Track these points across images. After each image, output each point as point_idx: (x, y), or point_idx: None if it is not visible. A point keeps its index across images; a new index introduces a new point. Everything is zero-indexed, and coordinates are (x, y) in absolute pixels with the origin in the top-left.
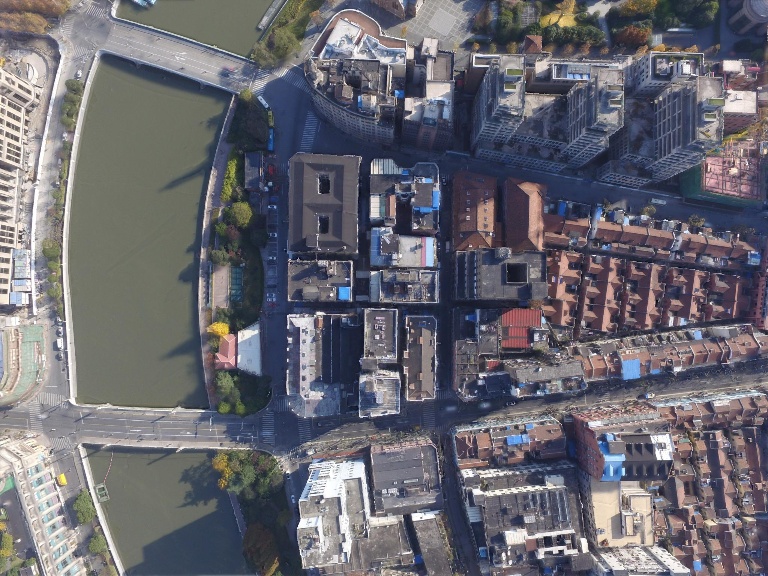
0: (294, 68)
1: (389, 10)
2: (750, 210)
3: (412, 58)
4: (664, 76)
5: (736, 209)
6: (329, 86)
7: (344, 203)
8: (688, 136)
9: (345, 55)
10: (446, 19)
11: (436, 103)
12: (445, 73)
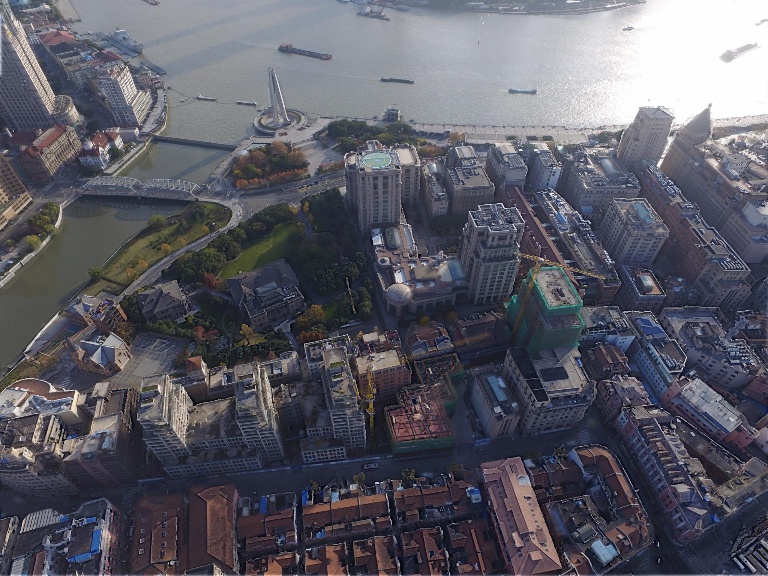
0: None
1: (96, 371)
2: (463, 447)
3: (82, 403)
4: (318, 358)
5: (446, 450)
6: None
7: None
8: (331, 398)
9: (8, 418)
10: (151, 365)
11: (99, 436)
12: (118, 407)
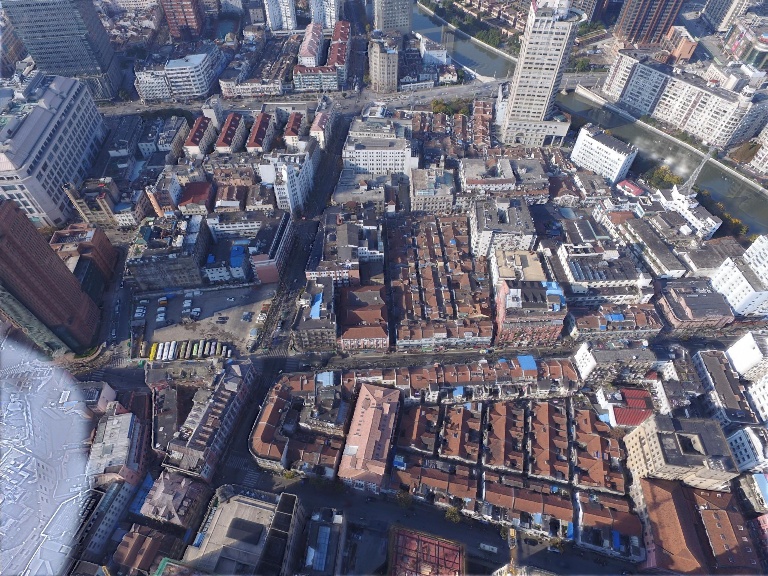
0: None
1: None
2: (378, 530)
3: None
4: None
5: None
6: None
7: None
8: None
9: None
10: None
11: None
12: None
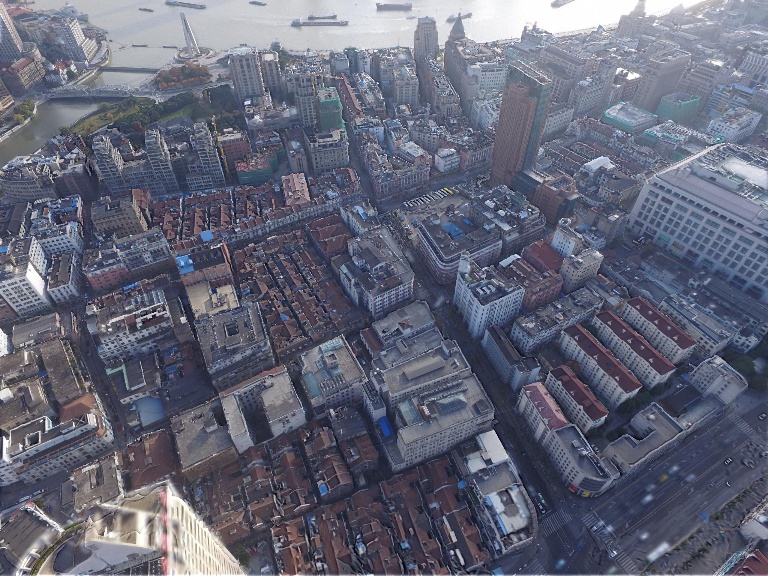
0: (5, 198)
1: None
2: None
3: (62, 162)
4: None
5: None
6: (7, 175)
7: (13, 217)
8: None
9: None
10: None
11: None
12: None
